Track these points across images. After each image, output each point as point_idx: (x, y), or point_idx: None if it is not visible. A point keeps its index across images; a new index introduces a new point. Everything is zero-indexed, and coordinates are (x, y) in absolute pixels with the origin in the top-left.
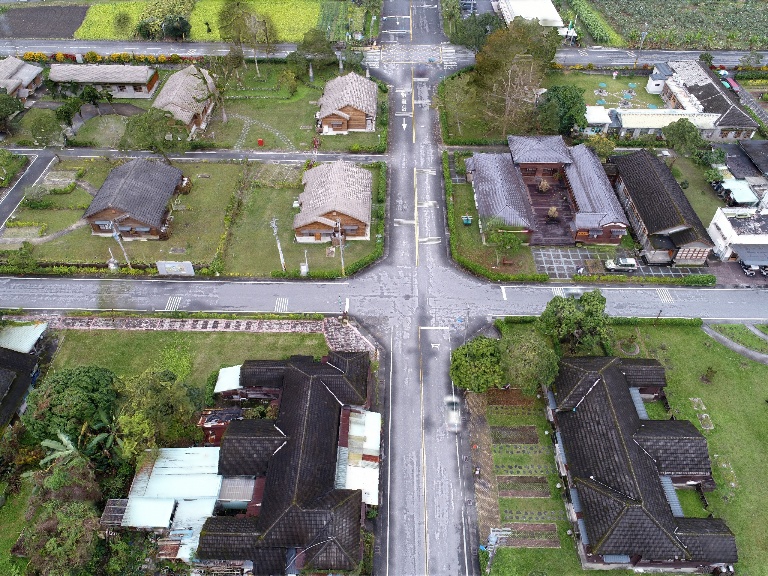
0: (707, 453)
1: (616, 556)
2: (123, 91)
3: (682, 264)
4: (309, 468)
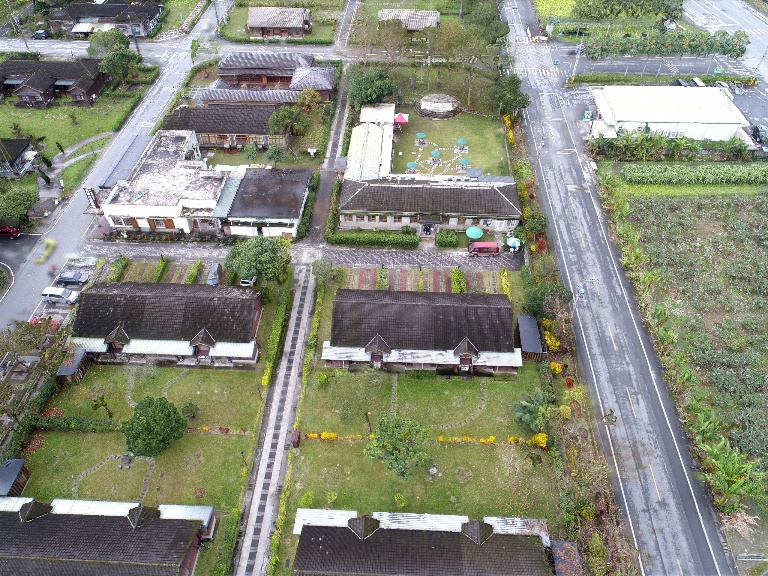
0: (20, 87)
1: None
2: None
3: None
4: (86, 7)
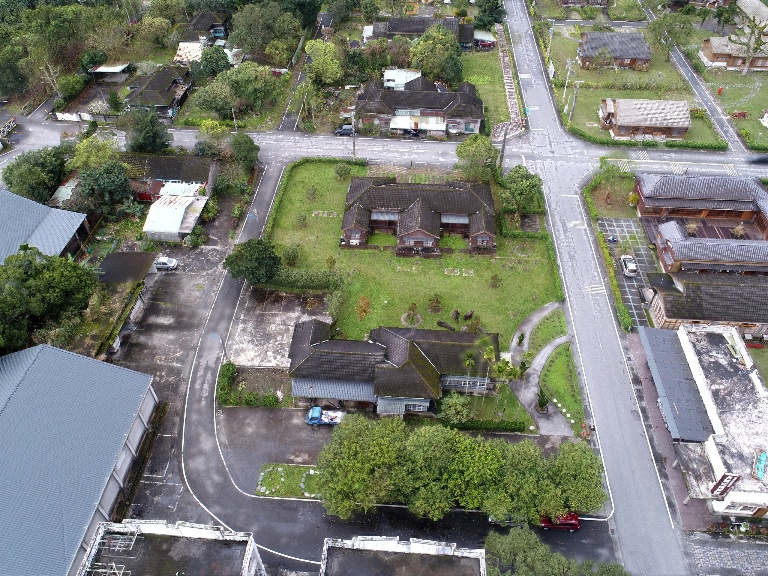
0: (410, 230)
1: None
2: None
3: (651, 316)
4: (403, 95)
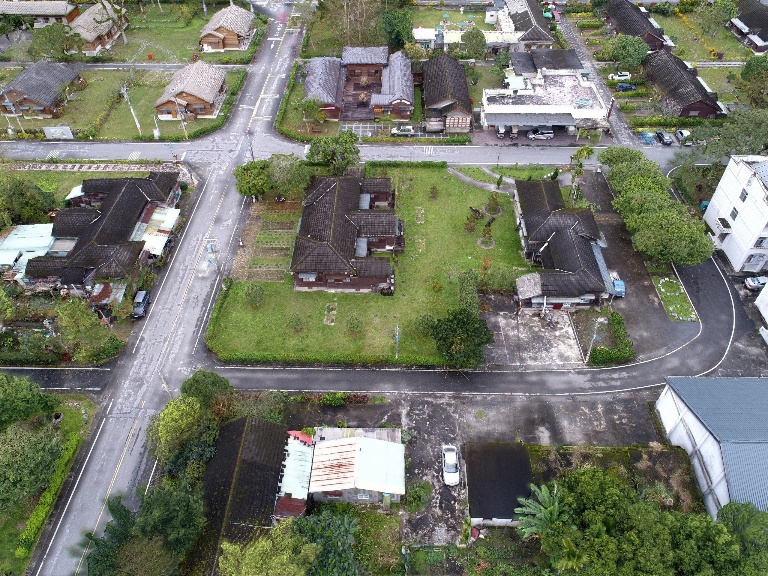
0: (395, 223)
1: (308, 274)
2: (47, 22)
3: (453, 132)
4: (110, 227)
